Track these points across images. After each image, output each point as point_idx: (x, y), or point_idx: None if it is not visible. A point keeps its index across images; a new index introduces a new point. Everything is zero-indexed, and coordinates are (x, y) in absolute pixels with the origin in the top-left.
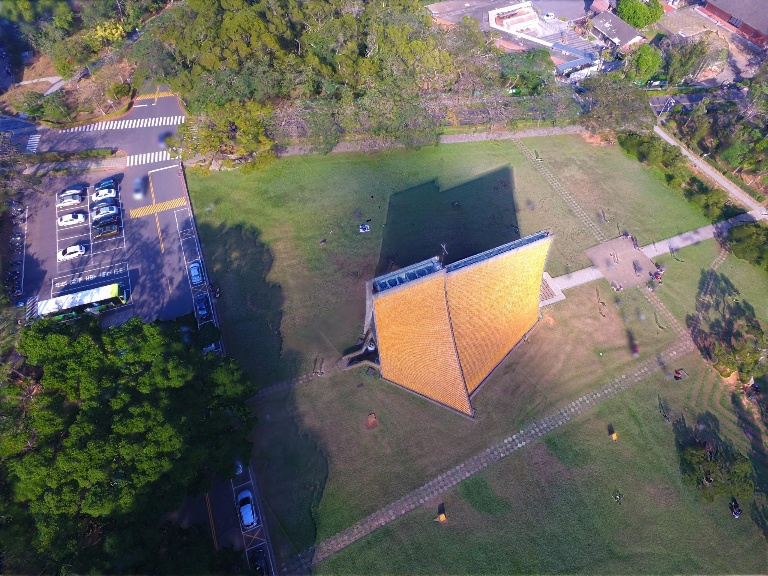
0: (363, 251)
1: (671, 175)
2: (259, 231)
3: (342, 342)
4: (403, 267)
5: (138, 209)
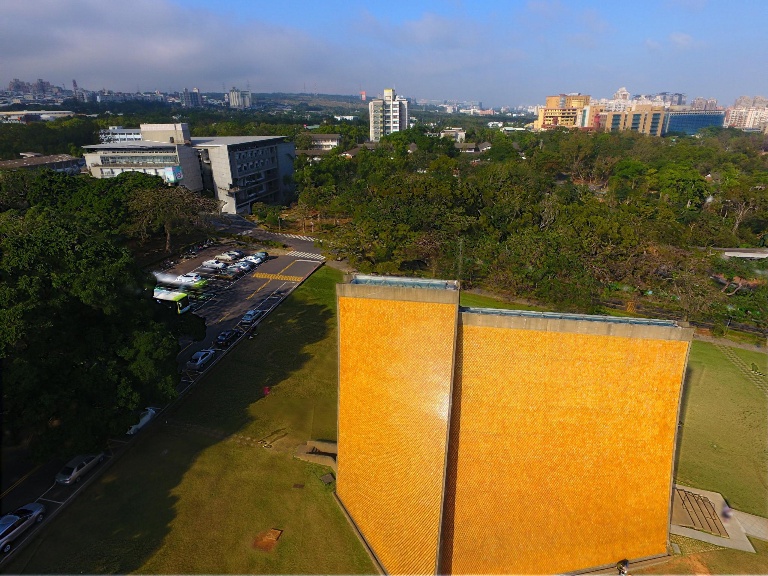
0: None
1: None
2: None
3: (325, 430)
4: None
5: (263, 274)
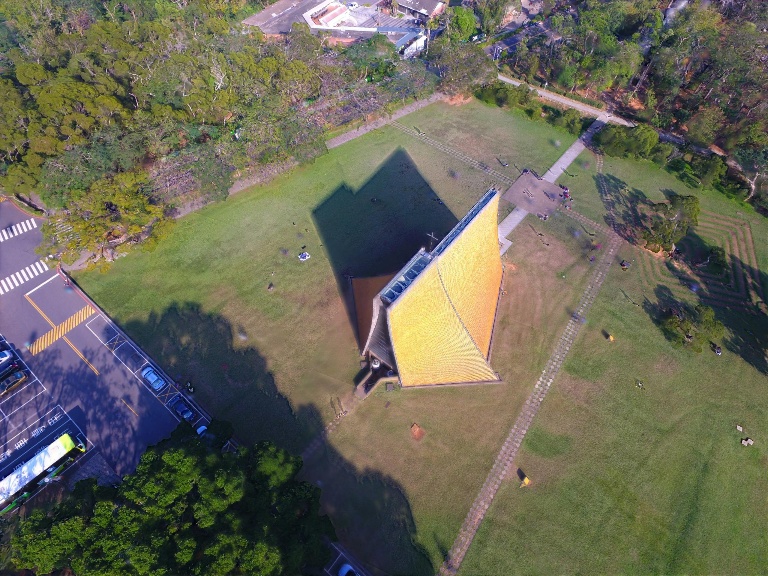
0: (315, 278)
1: (530, 110)
2: (197, 304)
3: (346, 373)
4: (362, 277)
5: (37, 341)
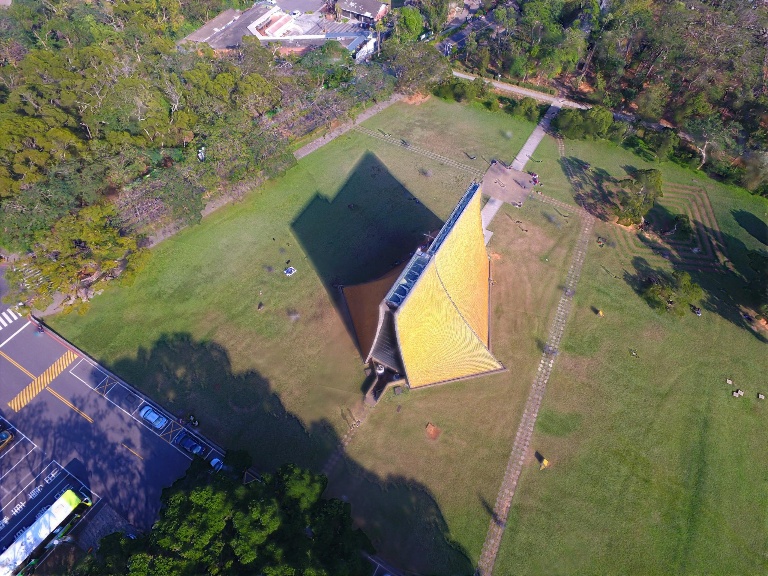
0: (305, 292)
1: (487, 102)
2: (186, 334)
3: (353, 383)
4: (352, 284)
5: (18, 396)
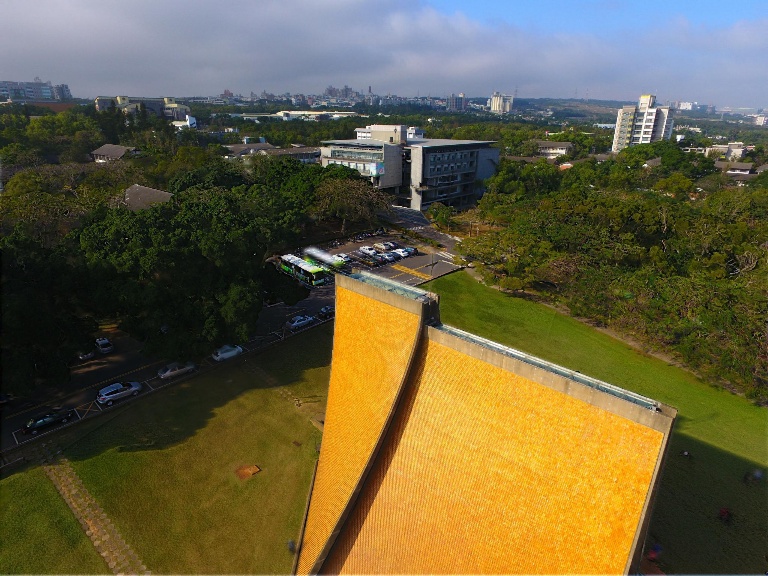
0: None
1: None
2: None
3: None
4: None
5: (402, 266)
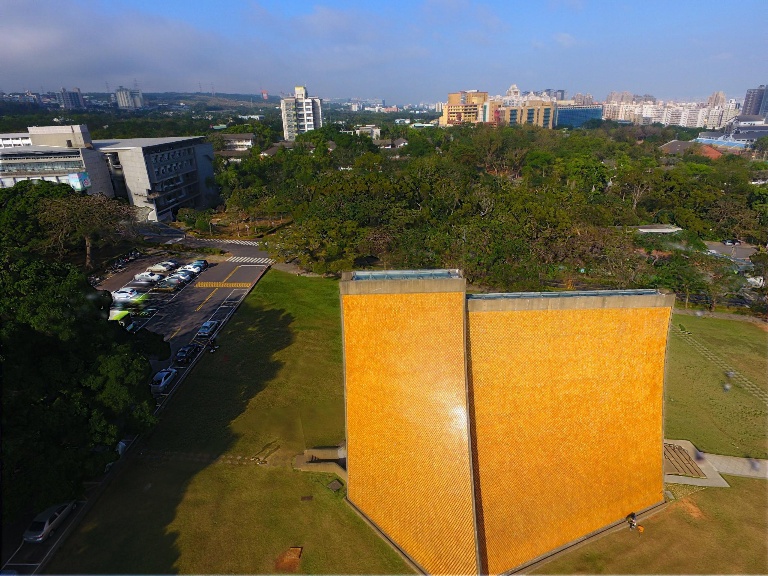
0: None
1: None
2: (300, 318)
3: (318, 437)
4: None
5: (206, 283)
